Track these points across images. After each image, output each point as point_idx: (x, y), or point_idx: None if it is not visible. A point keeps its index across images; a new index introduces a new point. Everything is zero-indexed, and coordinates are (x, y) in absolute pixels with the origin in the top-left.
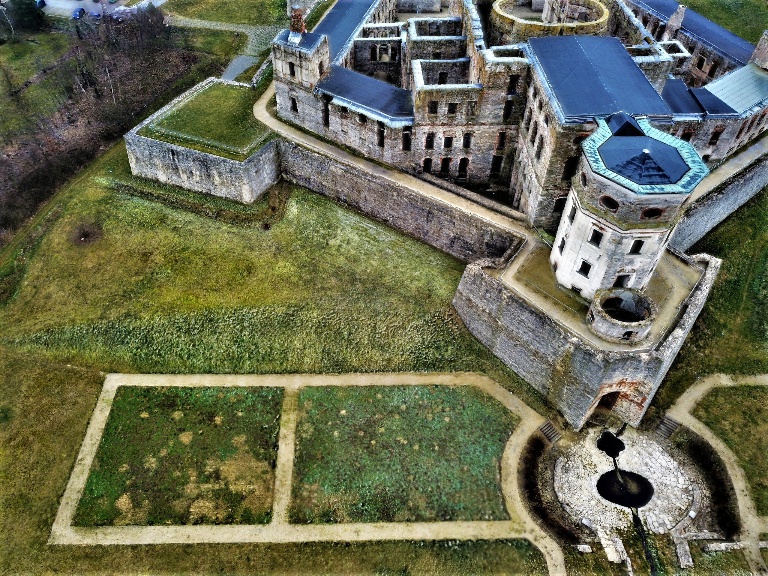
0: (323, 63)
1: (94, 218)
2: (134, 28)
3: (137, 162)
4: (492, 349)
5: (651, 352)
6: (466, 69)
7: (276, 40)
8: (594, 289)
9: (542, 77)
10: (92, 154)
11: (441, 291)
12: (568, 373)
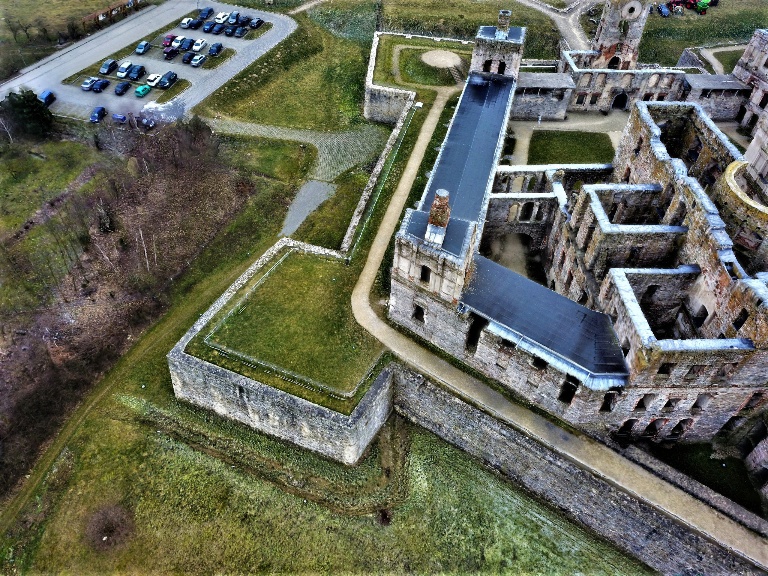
0: (468, 260)
1: (122, 492)
2: (169, 136)
3: (184, 386)
4: None
5: None
6: (690, 282)
7: (404, 233)
8: None
9: None
10: (116, 350)
11: None
12: None
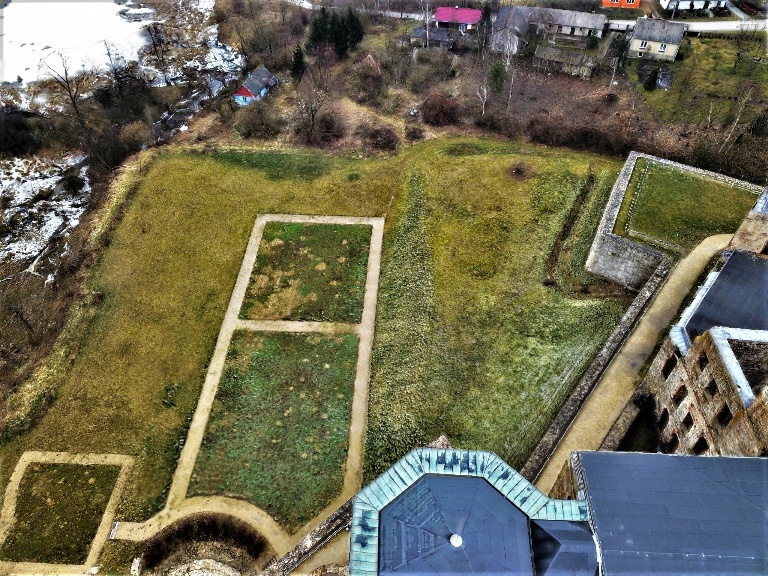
0: None
1: (542, 172)
2: None
3: None
4: None
5: None
6: None
7: None
8: None
9: None
10: None
11: None
12: None
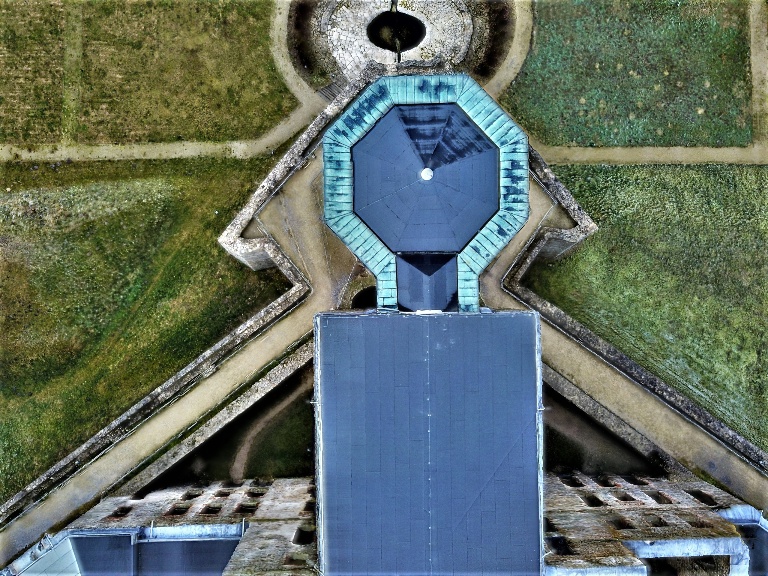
0: None
1: None
2: None
3: None
4: None
5: None
6: None
7: None
8: None
9: (540, 491)
10: None
11: (595, 259)
12: None
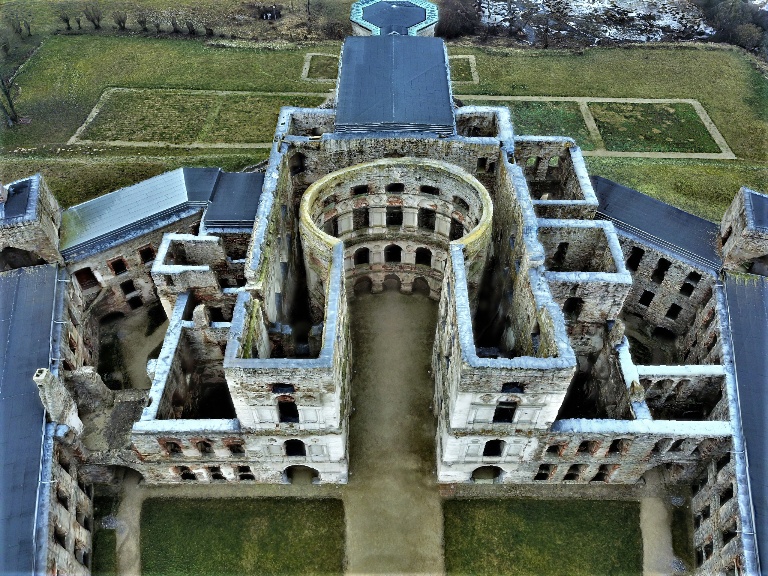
0: None
1: None
2: None
3: None
4: None
5: None
6: None
7: None
8: None
9: None
10: None
11: None
12: None
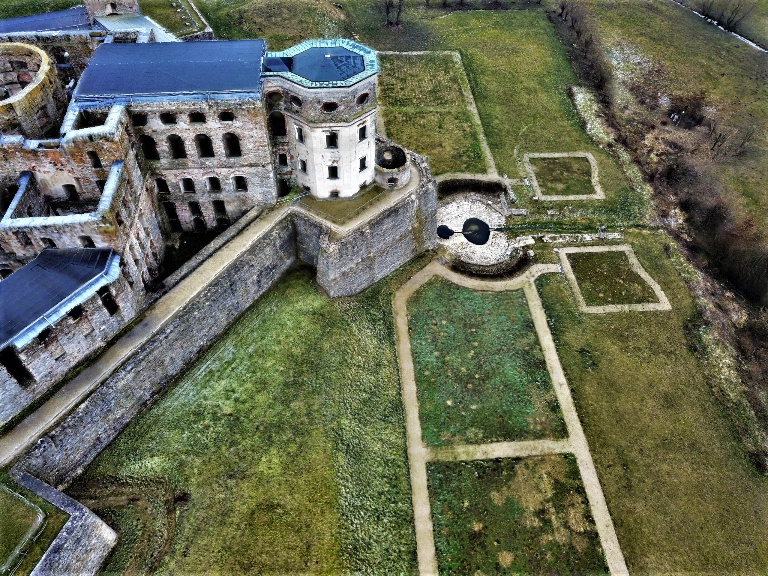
0: None
1: None
2: None
3: None
4: (374, 281)
5: (418, 162)
6: (35, 185)
7: None
8: (373, 170)
9: (166, 98)
10: None
11: (315, 305)
12: (421, 220)
